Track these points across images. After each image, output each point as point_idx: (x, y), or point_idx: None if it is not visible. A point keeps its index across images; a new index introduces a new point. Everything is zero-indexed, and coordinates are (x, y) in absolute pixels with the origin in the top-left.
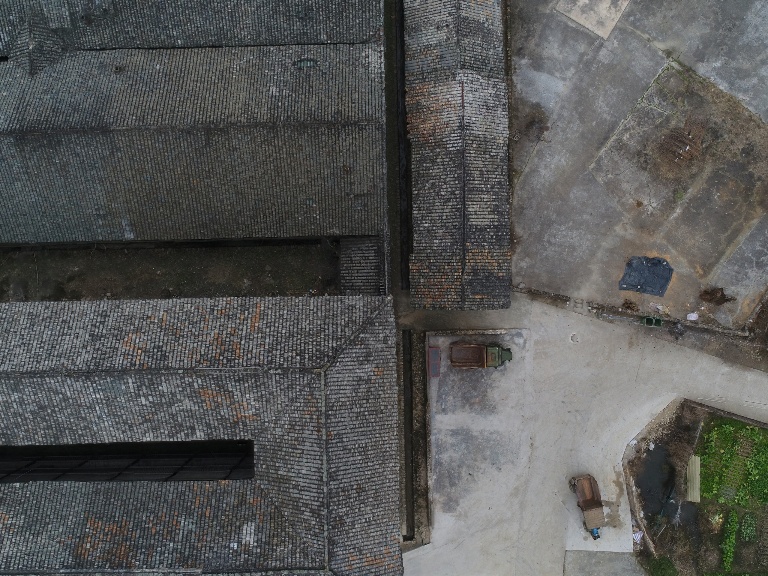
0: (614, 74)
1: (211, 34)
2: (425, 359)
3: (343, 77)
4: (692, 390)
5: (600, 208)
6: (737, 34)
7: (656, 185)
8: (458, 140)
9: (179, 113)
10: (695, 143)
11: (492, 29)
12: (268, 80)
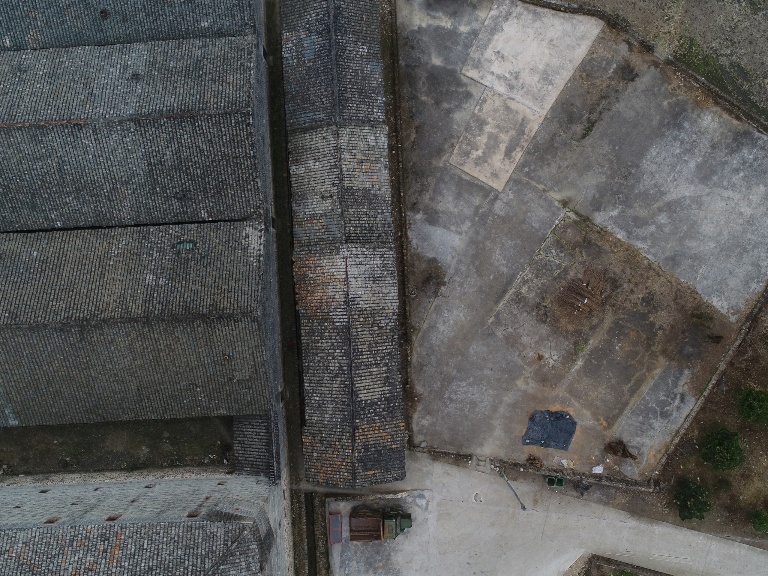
0: (510, 226)
1: (90, 216)
2: (326, 526)
3: (221, 261)
4: (599, 545)
5: (501, 362)
6: (633, 182)
7: (556, 338)
8: (344, 315)
9: (53, 308)
10: (594, 295)
11: (379, 194)
12: (145, 266)
